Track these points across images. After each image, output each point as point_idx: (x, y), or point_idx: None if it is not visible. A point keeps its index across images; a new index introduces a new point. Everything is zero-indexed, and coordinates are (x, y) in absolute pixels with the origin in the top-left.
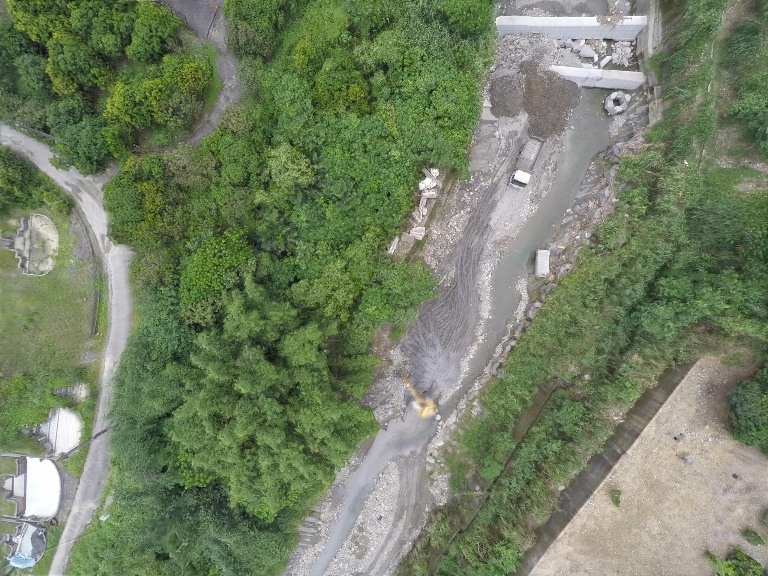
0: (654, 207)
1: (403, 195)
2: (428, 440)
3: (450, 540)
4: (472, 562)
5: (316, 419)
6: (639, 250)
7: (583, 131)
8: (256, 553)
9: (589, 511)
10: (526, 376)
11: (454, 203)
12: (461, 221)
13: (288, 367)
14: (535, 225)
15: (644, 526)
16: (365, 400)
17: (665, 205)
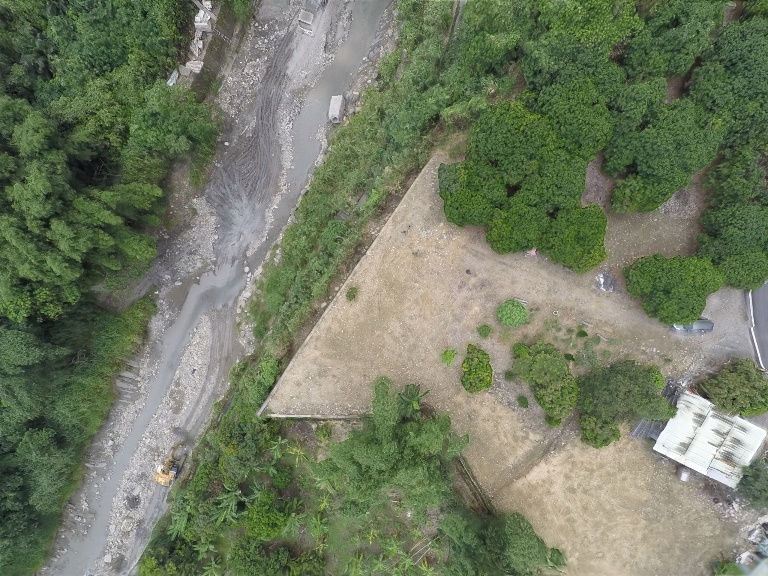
0: (423, 35)
1: (160, 14)
2: (239, 293)
3: (242, 377)
4: (248, 387)
5: (27, 193)
6: (408, 77)
7: None
8: (3, 349)
9: (333, 314)
10: (318, 217)
11: (248, 50)
12: (259, 70)
13: (9, 150)
14: (333, 74)
15: (387, 328)
16: (172, 250)
17: (425, 27)
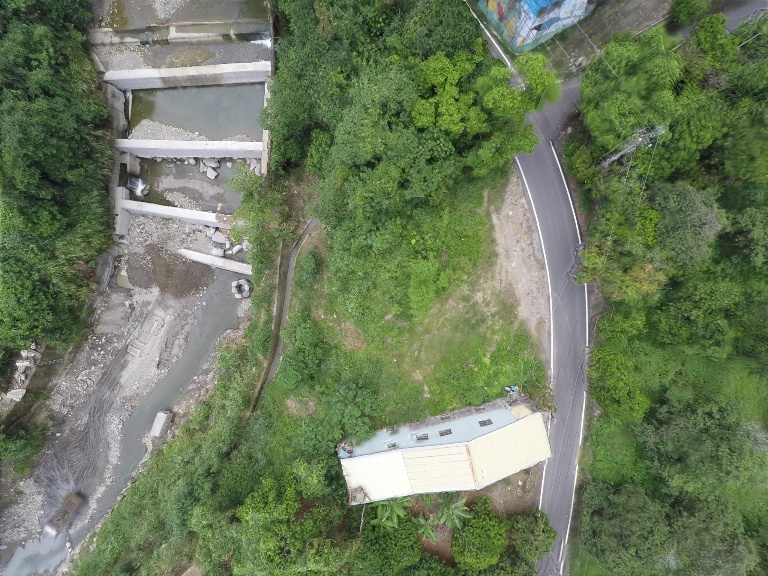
0: None
1: None
2: (59, 563)
3: None
4: None
5: None
6: None
7: (215, 308)
8: None
9: None
10: None
11: (84, 360)
12: (94, 375)
13: None
14: (165, 386)
15: None
16: None
17: None
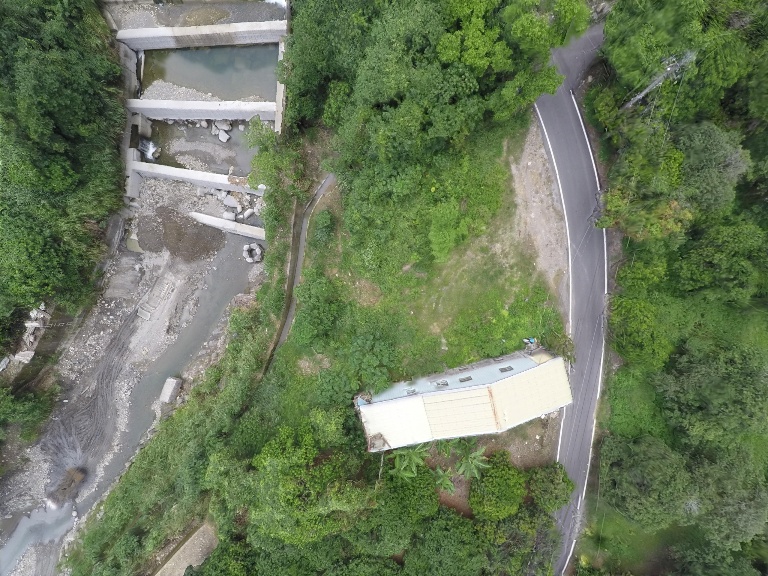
0: None
1: None
2: (65, 533)
3: None
4: None
5: None
6: None
7: (226, 273)
8: None
9: None
10: None
11: (92, 325)
12: (103, 340)
13: None
14: (175, 352)
15: None
16: (3, 490)
17: None
